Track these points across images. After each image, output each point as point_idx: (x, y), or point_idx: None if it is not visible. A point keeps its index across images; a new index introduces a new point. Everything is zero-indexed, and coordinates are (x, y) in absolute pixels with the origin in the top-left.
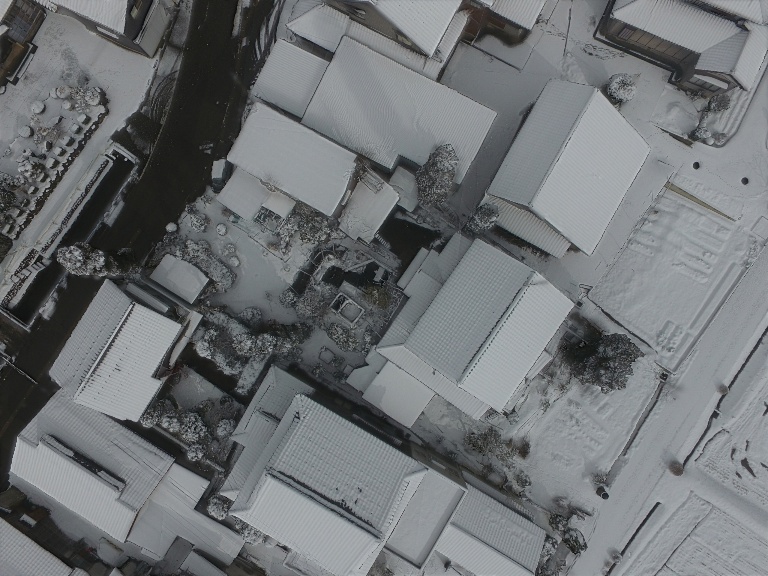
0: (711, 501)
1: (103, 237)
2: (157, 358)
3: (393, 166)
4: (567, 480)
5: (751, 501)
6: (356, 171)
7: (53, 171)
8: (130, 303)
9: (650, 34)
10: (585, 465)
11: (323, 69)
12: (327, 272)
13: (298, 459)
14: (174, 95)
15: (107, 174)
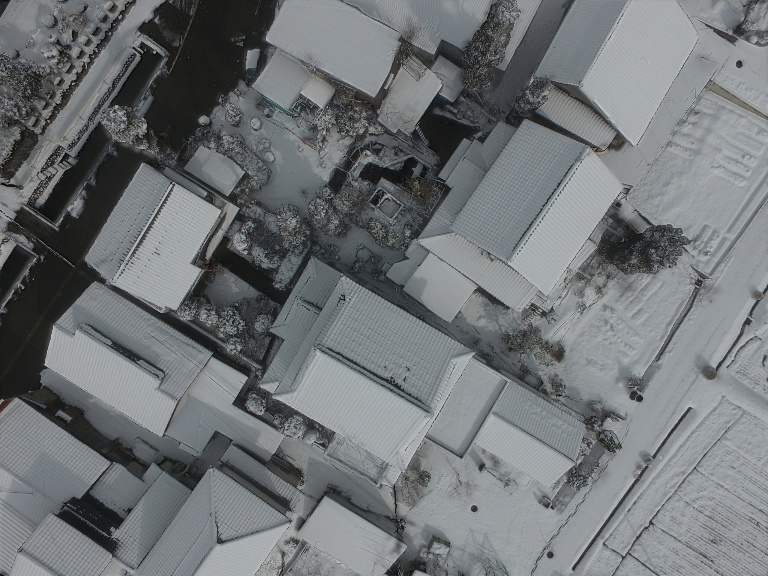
0: (742, 406)
1: None
2: (196, 244)
3: (435, 54)
4: (601, 385)
5: None
6: (400, 52)
7: (79, 63)
8: (169, 183)
9: None
10: (619, 370)
11: None
12: (364, 168)
13: (346, 337)
14: None
15: (134, 69)
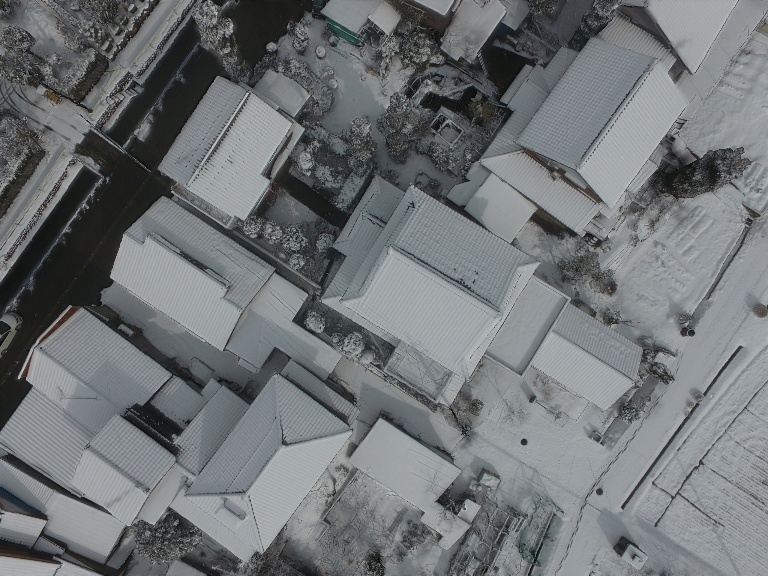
0: None
1: (200, 60)
2: (267, 155)
3: None
4: (652, 320)
5: None
6: None
7: None
8: (245, 92)
9: None
10: (670, 306)
11: None
12: (425, 97)
13: (416, 240)
14: None
15: None
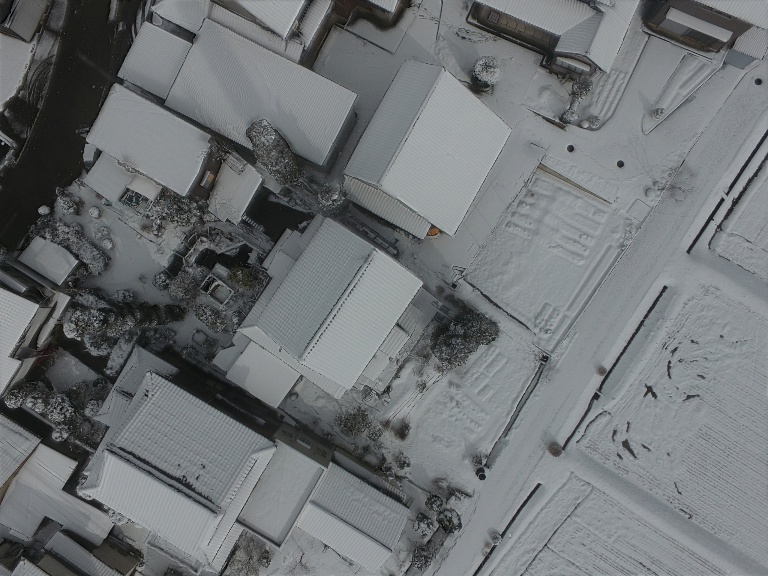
0: (591, 482)
1: None
2: (14, 338)
3: None
4: (447, 461)
5: (632, 482)
6: (212, 152)
7: None
8: None
9: (511, 16)
10: (465, 446)
11: None
12: (200, 254)
13: (141, 436)
14: (51, 79)
15: None
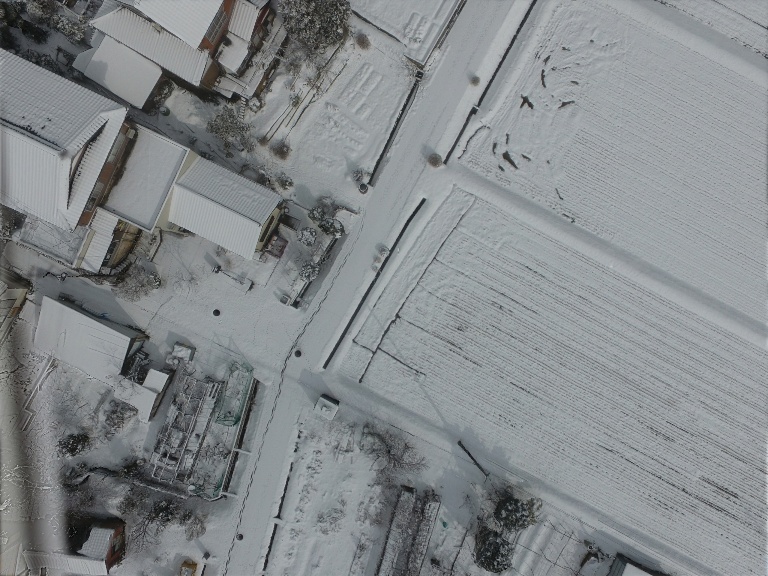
0: (473, 192)
1: None
2: None
3: None
4: (330, 181)
5: (514, 191)
6: None
7: None
8: None
9: None
10: (347, 166)
11: None
12: None
13: None
14: None
15: None
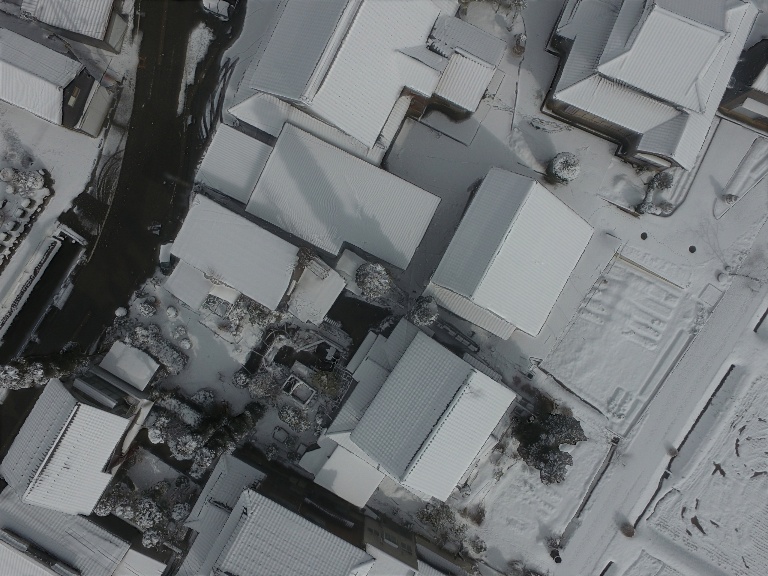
0: (662, 559)
1: (53, 320)
2: (106, 454)
3: (340, 250)
4: (522, 544)
5: (701, 557)
6: (300, 263)
7: None
8: (75, 403)
9: (593, 115)
10: (539, 528)
11: (267, 155)
12: (279, 352)
13: (245, 558)
14: (120, 175)
15: (56, 255)
